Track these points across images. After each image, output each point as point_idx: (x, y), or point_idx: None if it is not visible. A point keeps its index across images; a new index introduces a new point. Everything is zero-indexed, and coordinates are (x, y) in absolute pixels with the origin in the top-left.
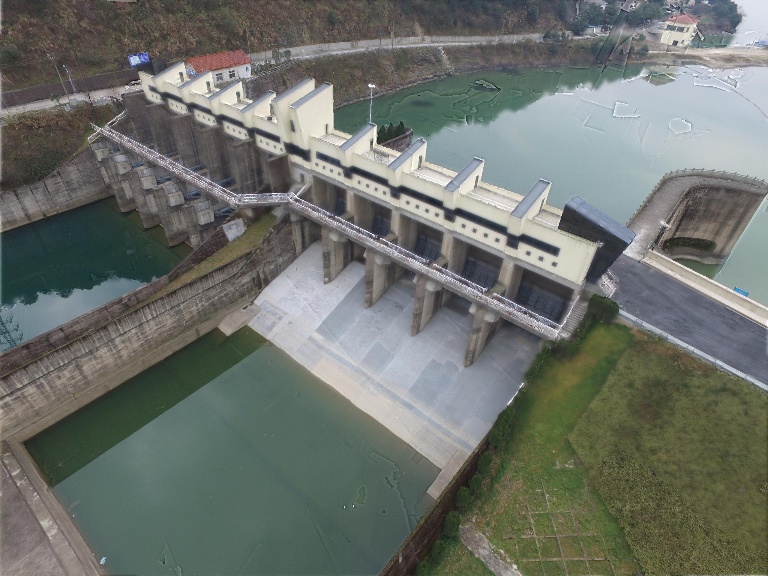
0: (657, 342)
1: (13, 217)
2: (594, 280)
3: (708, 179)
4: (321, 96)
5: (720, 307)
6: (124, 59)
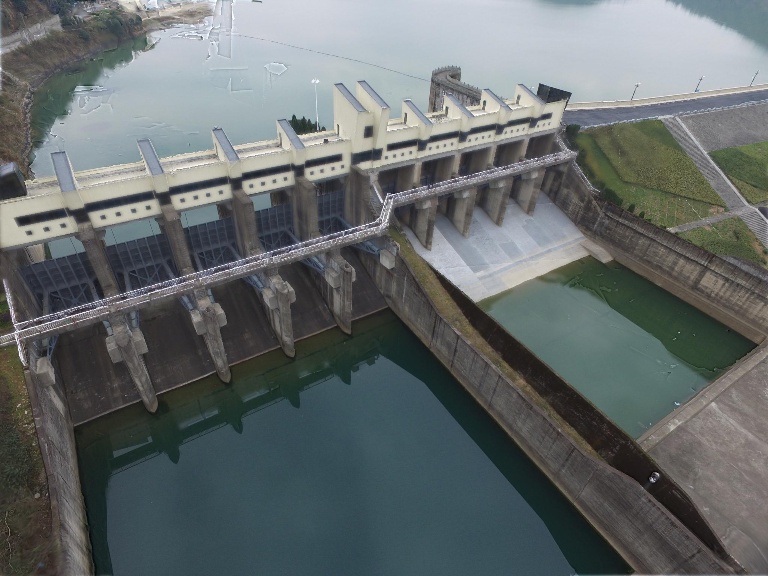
0: (595, 129)
1: (86, 568)
2: None
3: (447, 74)
4: None
5: None
6: None
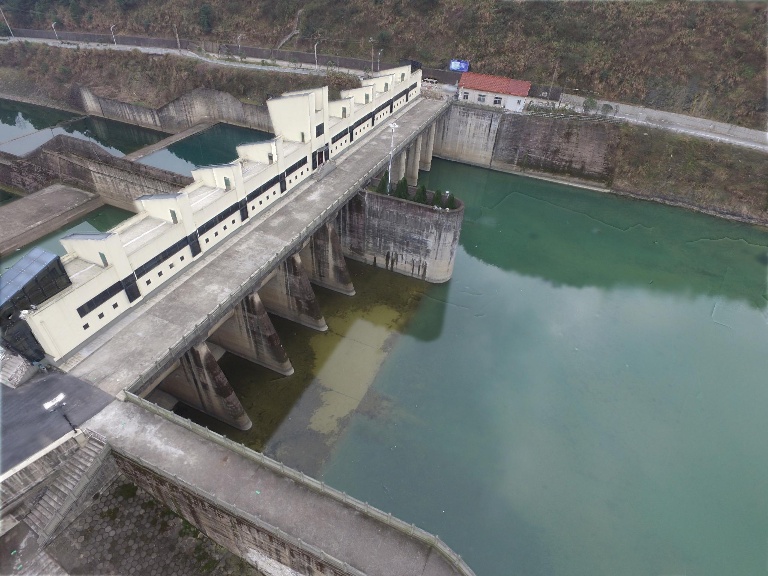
0: None
1: None
2: None
3: None
4: (296, 101)
5: None
6: (449, 62)
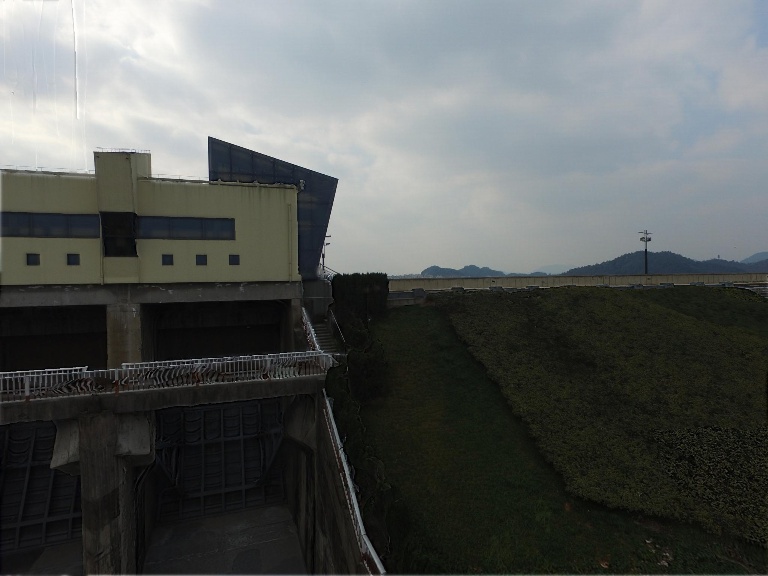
0: (464, 294)
1: None
2: (311, 271)
3: None
4: None
5: None
6: None
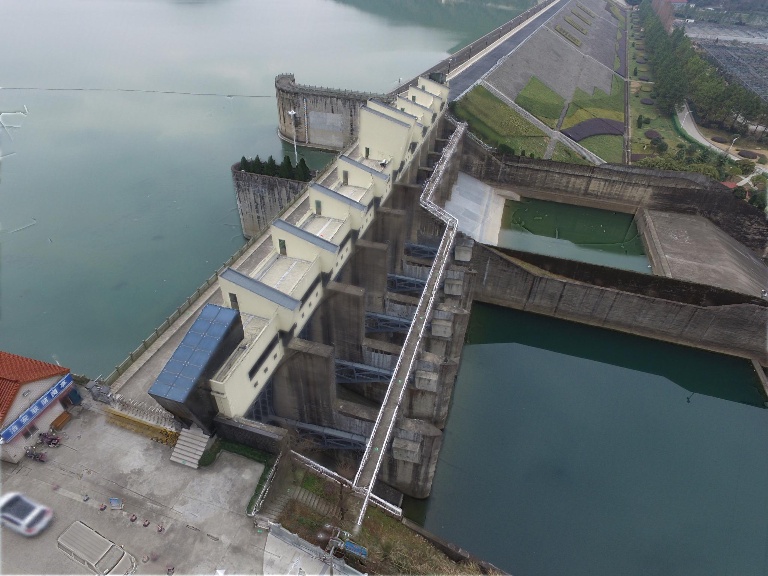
0: None
1: None
2: None
3: None
4: None
5: None
6: None
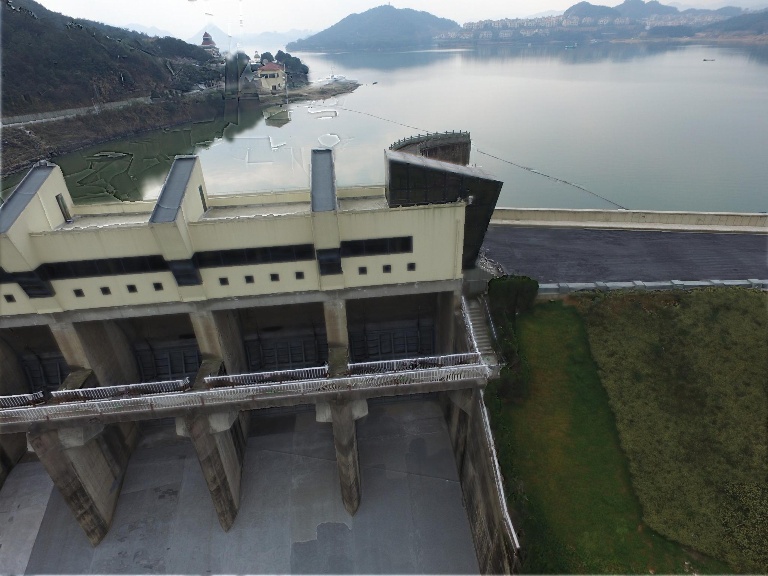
0: (605, 298)
1: None
2: (471, 263)
3: (423, 142)
4: None
5: (583, 231)
6: None
